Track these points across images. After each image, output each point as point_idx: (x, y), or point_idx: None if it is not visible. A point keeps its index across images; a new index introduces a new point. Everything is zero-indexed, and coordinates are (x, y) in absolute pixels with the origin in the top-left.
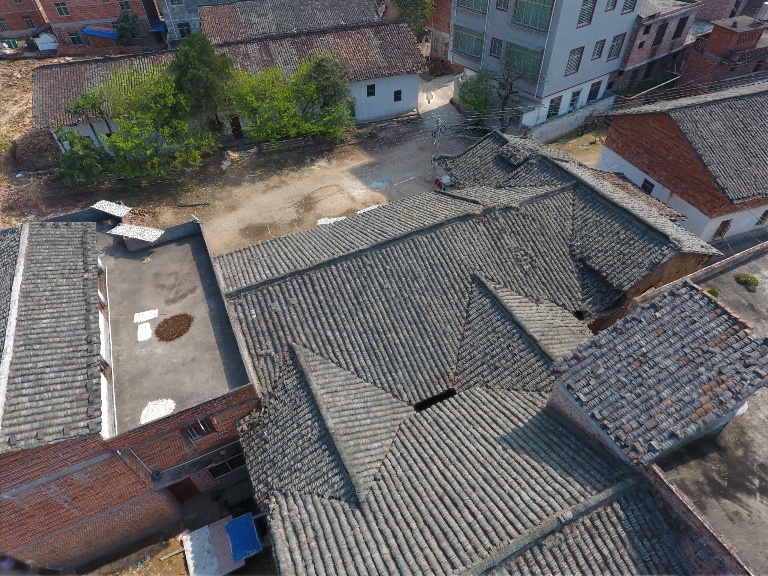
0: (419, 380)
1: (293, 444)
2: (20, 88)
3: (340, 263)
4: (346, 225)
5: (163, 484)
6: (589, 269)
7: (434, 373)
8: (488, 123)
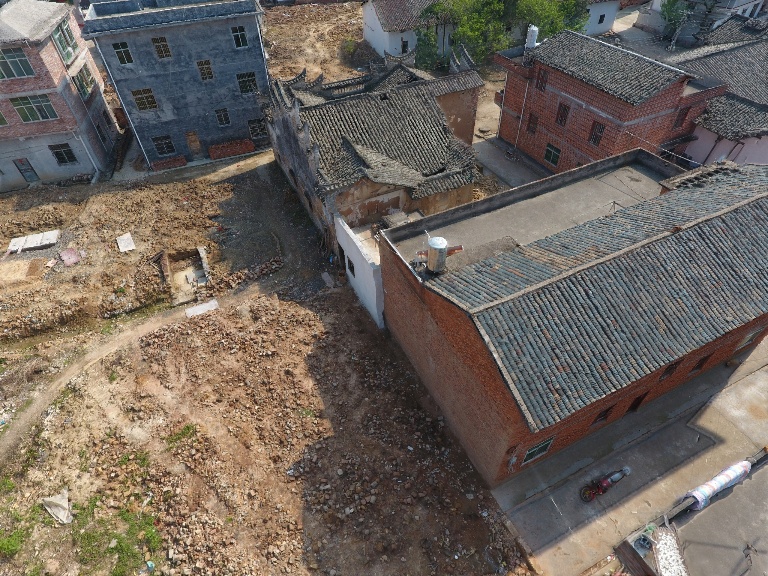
0: None
1: (741, 117)
2: (298, 22)
3: (714, 57)
4: None
5: (659, 150)
6: None
7: None
8: None
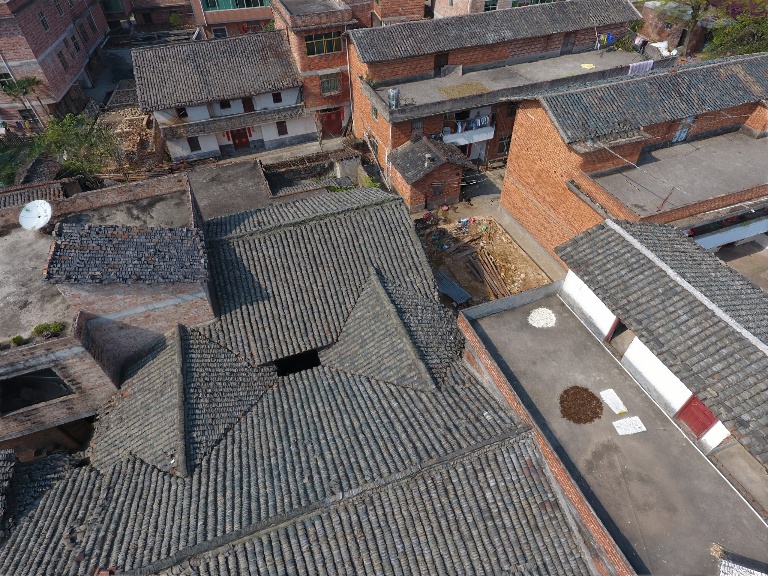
0: (309, 380)
1: None
2: None
3: None
4: None
5: None
6: (5, 516)
7: (291, 386)
8: None
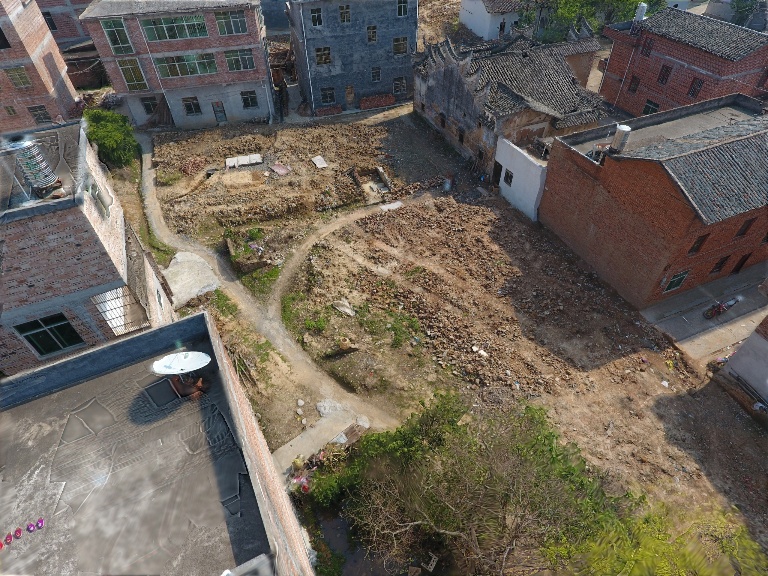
0: None
1: None
2: None
3: None
4: None
5: None
6: None
7: None
8: None
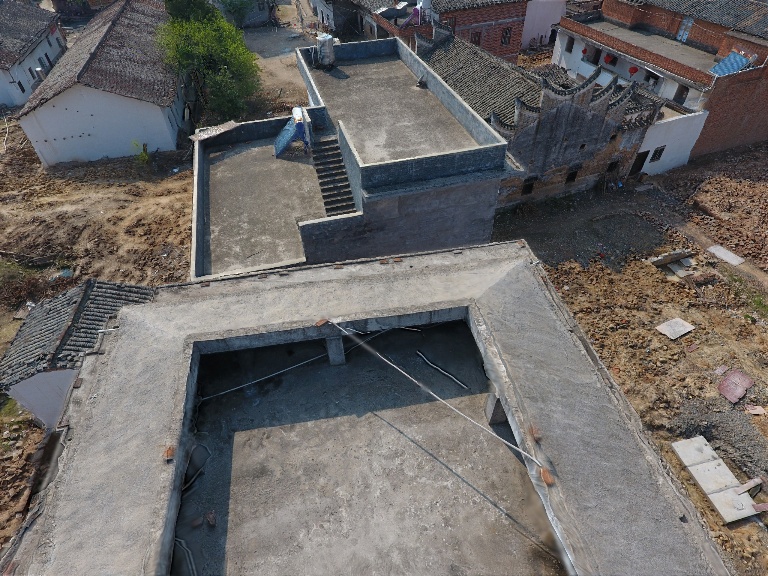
0: None
1: None
2: None
3: None
4: (381, 3)
5: None
6: None
7: None
8: (246, 19)
